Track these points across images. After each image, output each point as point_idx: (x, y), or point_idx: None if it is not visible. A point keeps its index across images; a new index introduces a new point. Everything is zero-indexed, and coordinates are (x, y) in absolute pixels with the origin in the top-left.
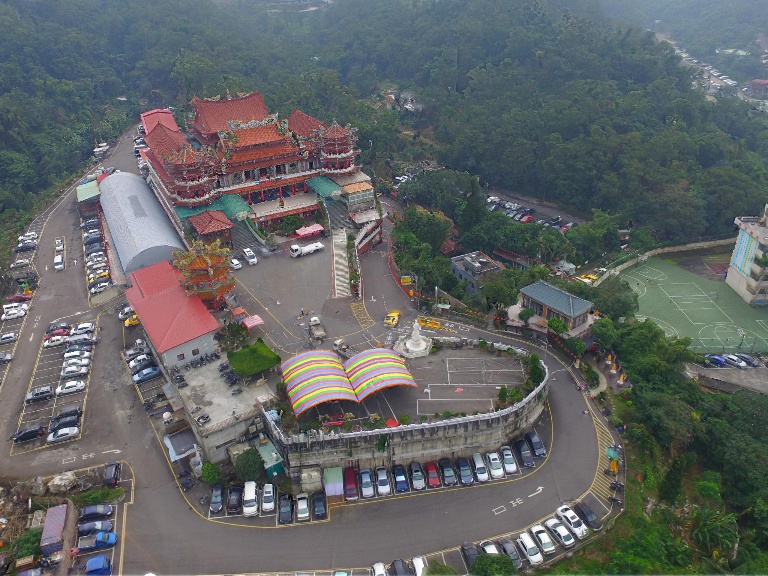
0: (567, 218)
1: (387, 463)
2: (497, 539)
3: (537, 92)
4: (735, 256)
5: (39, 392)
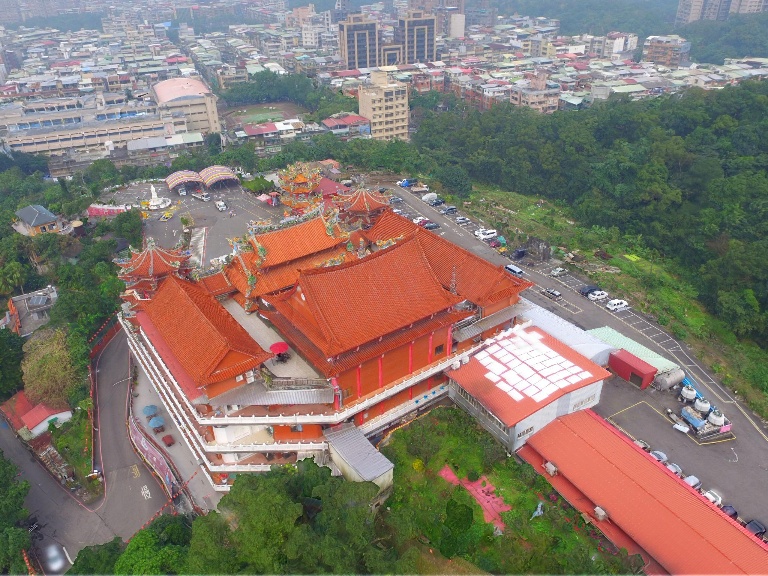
0: None
1: None
2: None
3: None
4: None
5: None
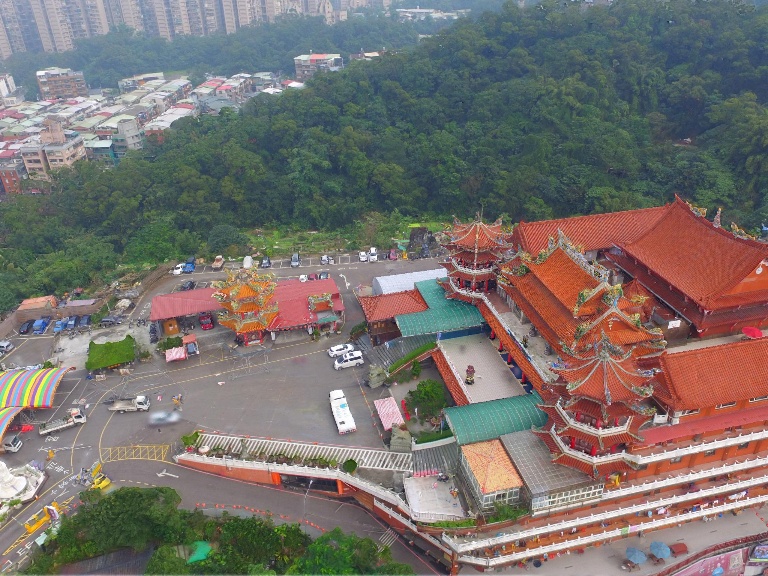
0: None
1: None
2: None
3: None
4: None
5: None
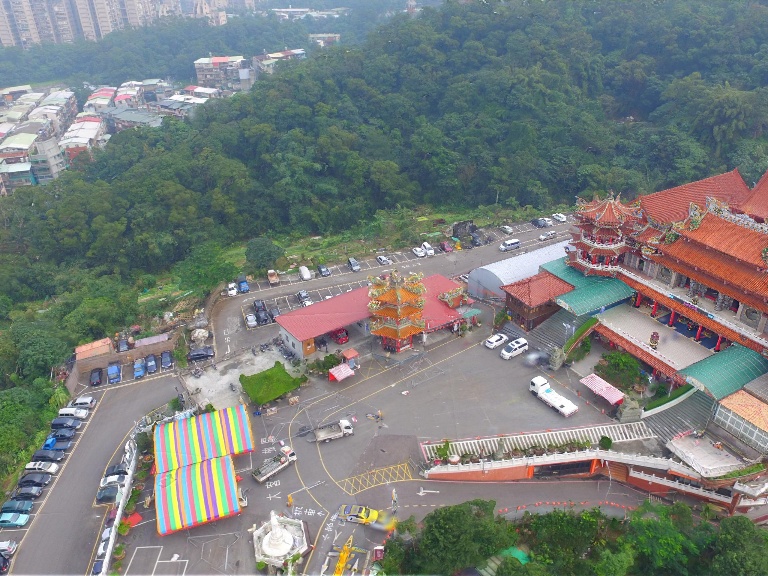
0: None
1: None
2: None
3: None
4: None
5: None
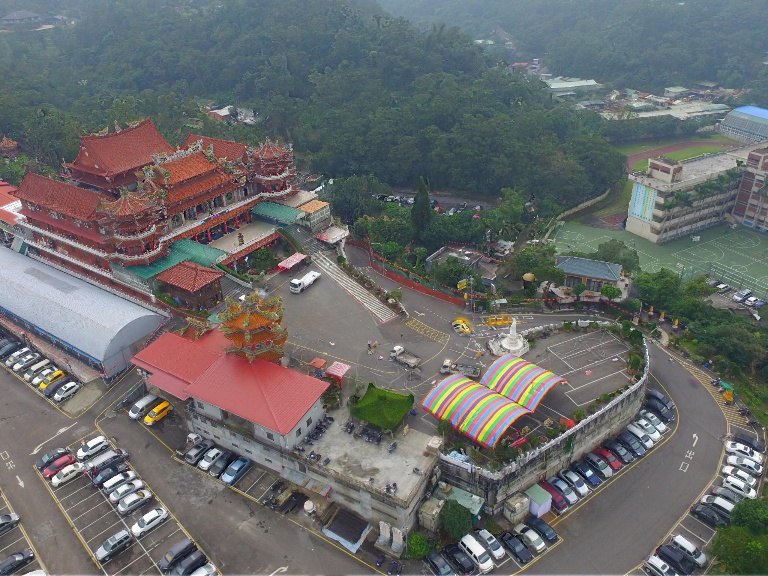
0: (468, 203)
1: (565, 464)
2: (708, 492)
3: (385, 90)
4: (633, 206)
5: (116, 542)
